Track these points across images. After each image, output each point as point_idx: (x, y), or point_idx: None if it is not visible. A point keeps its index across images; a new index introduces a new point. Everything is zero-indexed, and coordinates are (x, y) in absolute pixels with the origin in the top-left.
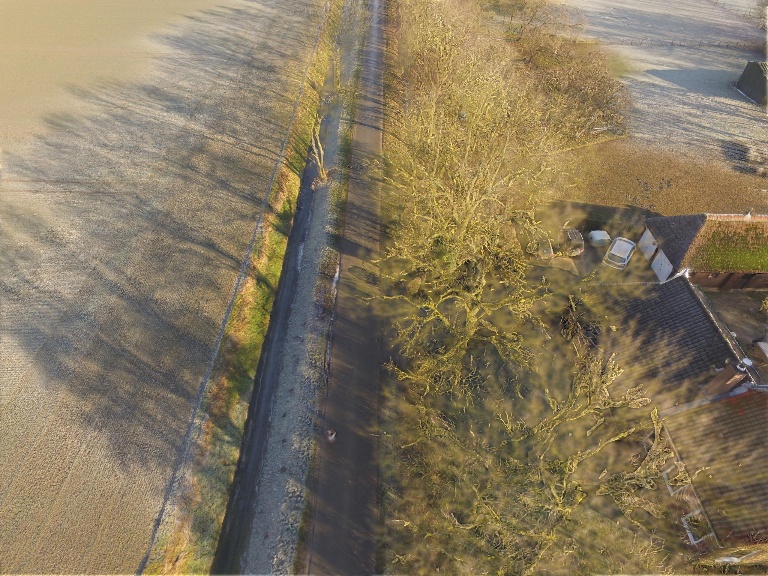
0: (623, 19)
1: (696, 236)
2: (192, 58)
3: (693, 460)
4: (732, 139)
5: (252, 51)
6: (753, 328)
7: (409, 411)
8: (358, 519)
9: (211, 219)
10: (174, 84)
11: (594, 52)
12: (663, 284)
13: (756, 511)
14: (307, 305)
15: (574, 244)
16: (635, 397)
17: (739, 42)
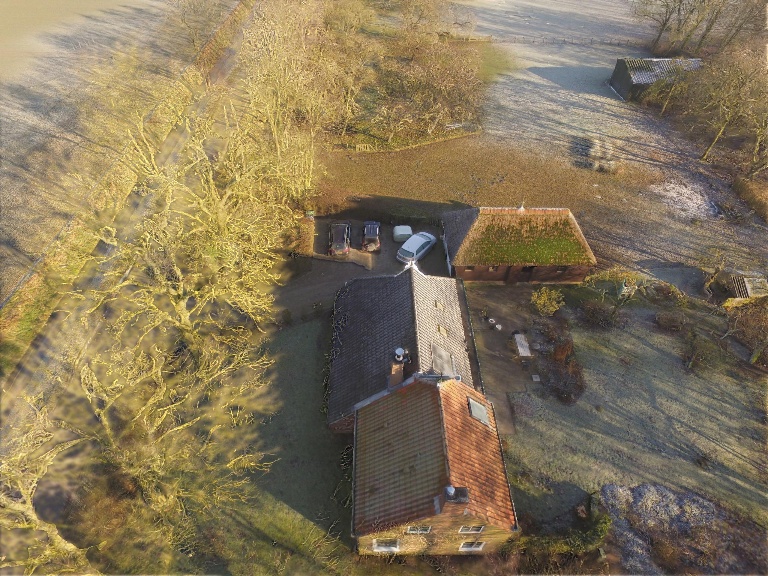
0: (526, 18)
1: (470, 230)
2: (72, 57)
3: (362, 450)
4: (584, 135)
5: (137, 50)
6: (523, 321)
7: (140, 406)
8: (42, 514)
9: (21, 217)
10: (42, 83)
11: (465, 50)
12: (396, 277)
13: (384, 500)
14: (86, 302)
15: (368, 239)
16: (255, 387)
17: (633, 40)
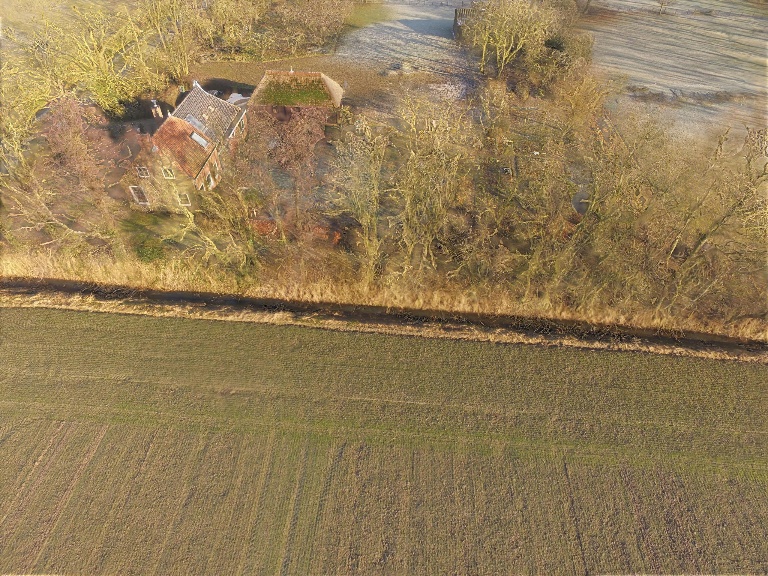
0: None
1: (259, 83)
2: (62, 7)
3: None
4: (406, 58)
5: (110, 4)
6: None
7: None
8: None
9: None
10: None
11: None
12: None
13: None
14: None
15: None
16: None
17: None
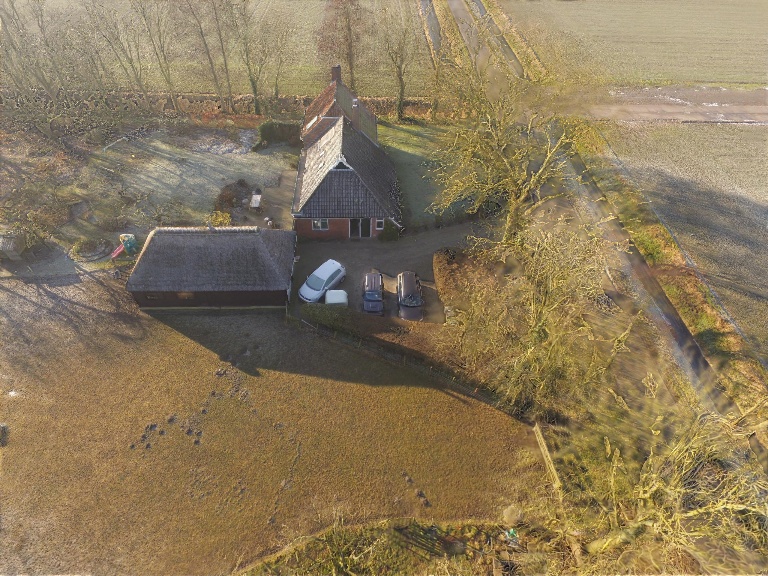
0: None
1: None
2: None
3: None
4: None
5: None
6: None
7: None
8: None
9: None
10: None
11: None
12: None
13: None
14: None
15: None
16: None
17: None
